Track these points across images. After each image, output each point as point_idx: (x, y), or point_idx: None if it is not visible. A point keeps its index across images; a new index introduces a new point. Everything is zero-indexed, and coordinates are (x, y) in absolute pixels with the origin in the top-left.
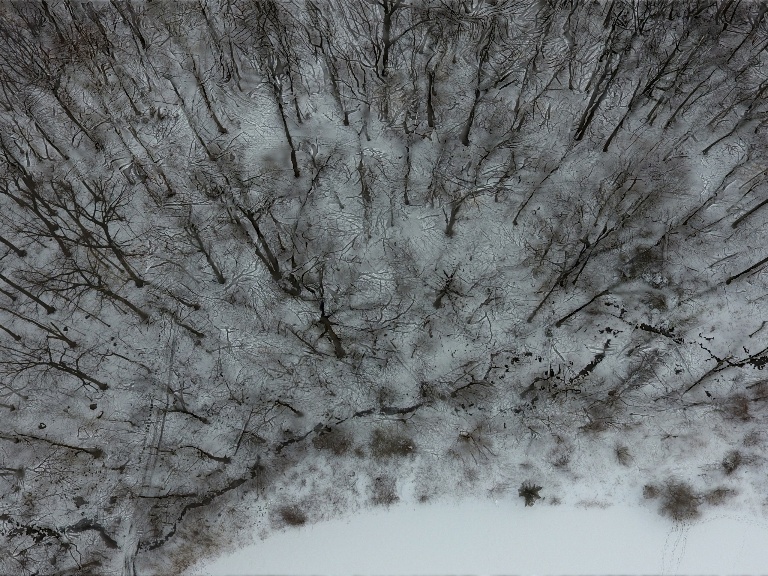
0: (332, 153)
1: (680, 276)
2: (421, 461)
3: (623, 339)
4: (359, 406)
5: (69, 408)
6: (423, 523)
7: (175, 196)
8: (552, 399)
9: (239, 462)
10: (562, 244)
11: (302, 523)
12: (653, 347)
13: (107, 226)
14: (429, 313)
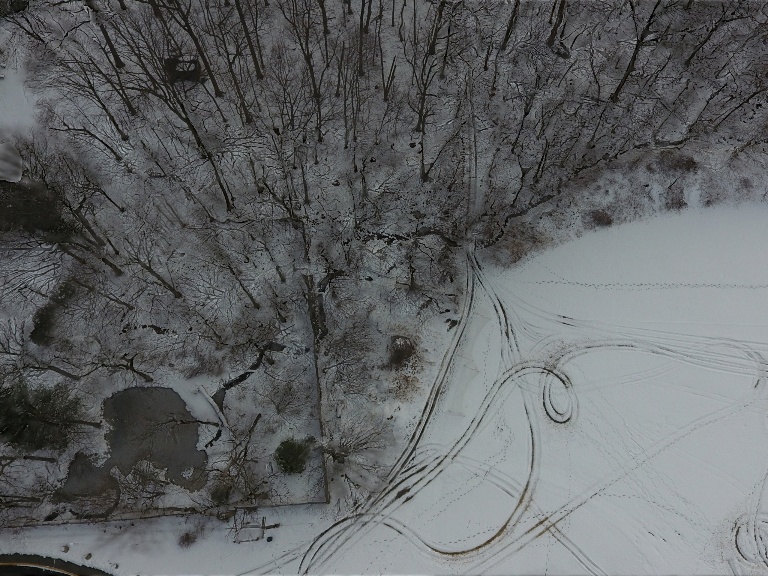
0: None
1: None
2: (703, 174)
3: None
4: (637, 140)
5: (393, 146)
6: (710, 222)
7: None
8: None
9: (546, 182)
10: None
11: (609, 224)
12: None
13: None
14: (682, 70)
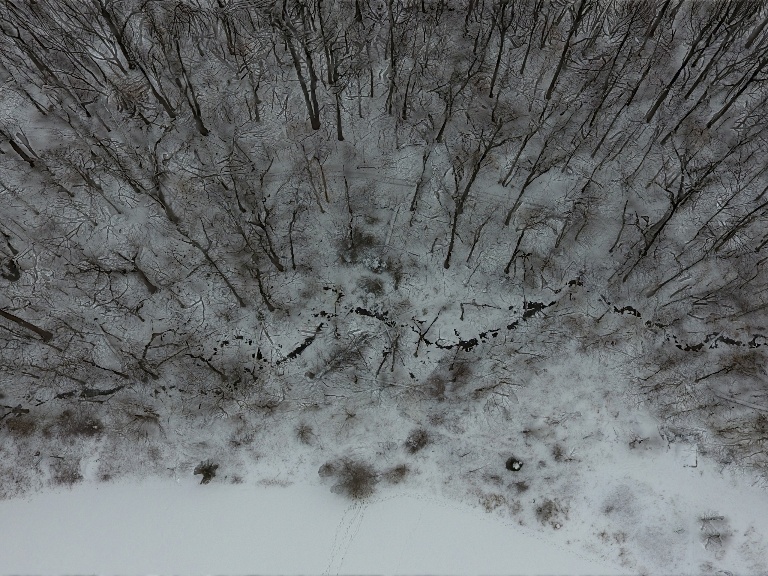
0: (71, 144)
1: (399, 261)
2: (107, 441)
3: (334, 322)
4: (61, 388)
5: None
6: (104, 501)
7: None
8: (253, 381)
9: None
10: (288, 230)
11: None
12: (363, 330)
13: None
14: (144, 298)
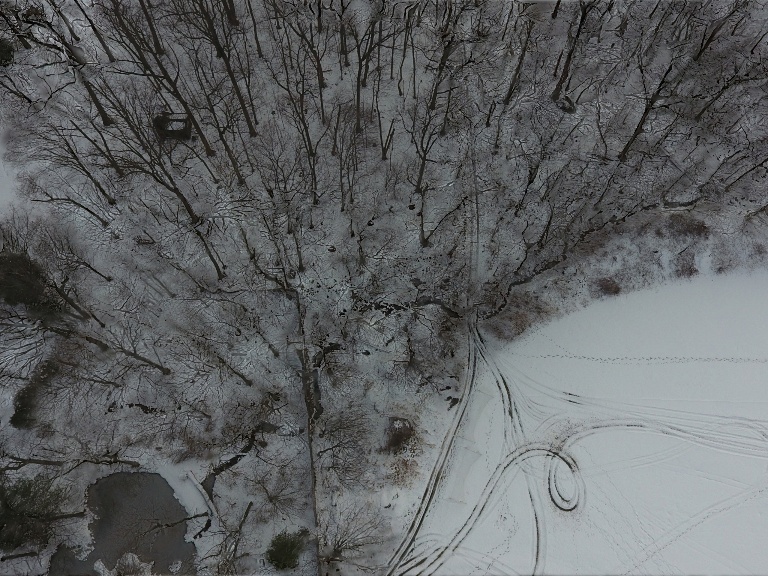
0: None
1: None
2: (714, 239)
3: None
4: (645, 201)
5: (392, 208)
6: (722, 291)
7: (449, 36)
8: None
9: (550, 247)
10: None
11: (617, 293)
12: None
13: (456, 22)
14: (692, 125)
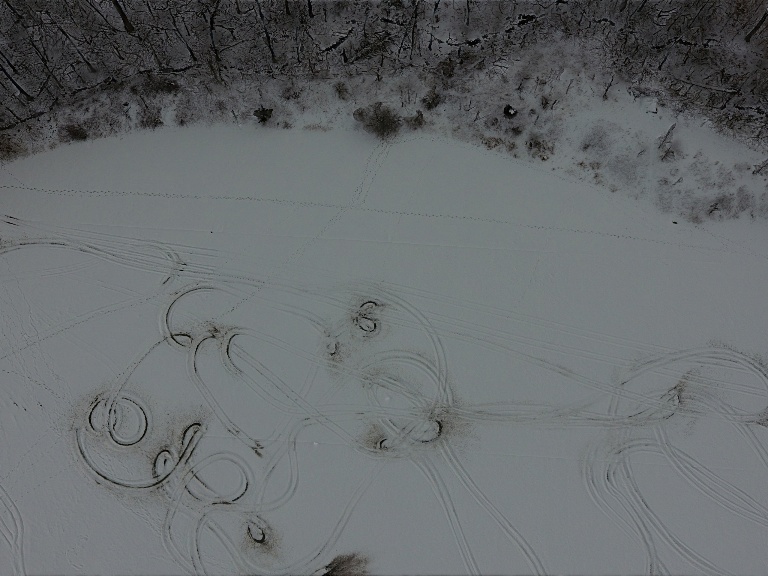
0: None
1: None
2: (182, 96)
3: (363, 25)
4: (142, 67)
5: None
6: (180, 140)
7: None
8: (298, 63)
9: (41, 101)
10: None
11: (84, 139)
12: None
13: None
14: None
